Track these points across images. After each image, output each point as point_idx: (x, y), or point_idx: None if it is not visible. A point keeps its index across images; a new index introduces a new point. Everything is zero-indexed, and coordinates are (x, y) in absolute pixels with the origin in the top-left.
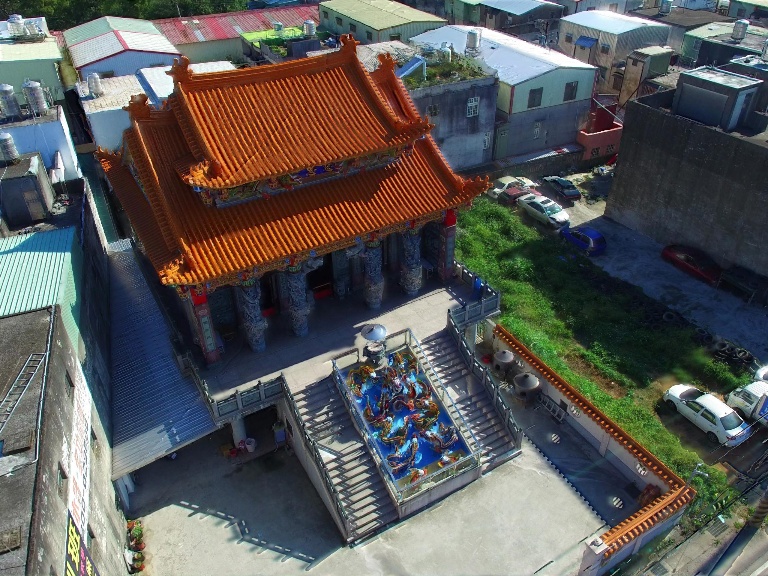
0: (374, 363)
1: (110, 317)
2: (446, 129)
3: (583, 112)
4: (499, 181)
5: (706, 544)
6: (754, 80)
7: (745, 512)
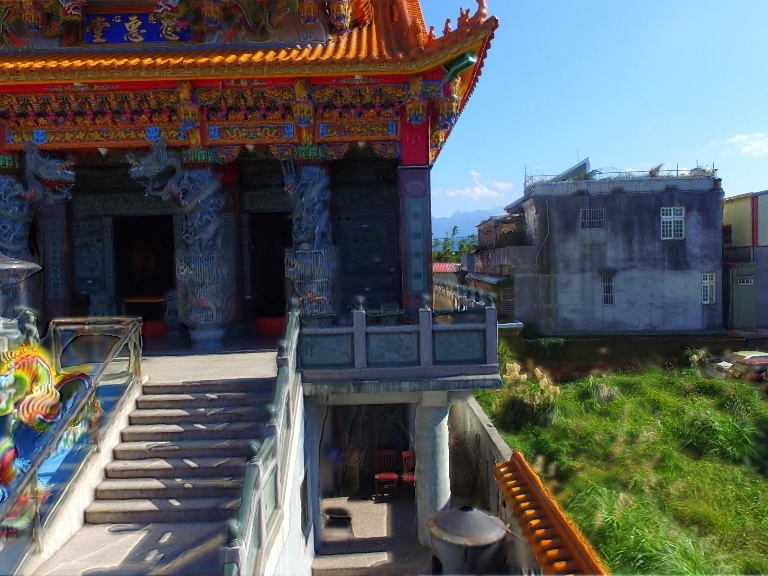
0: None
1: None
2: (620, 254)
3: None
4: (732, 353)
5: None
6: None
7: None
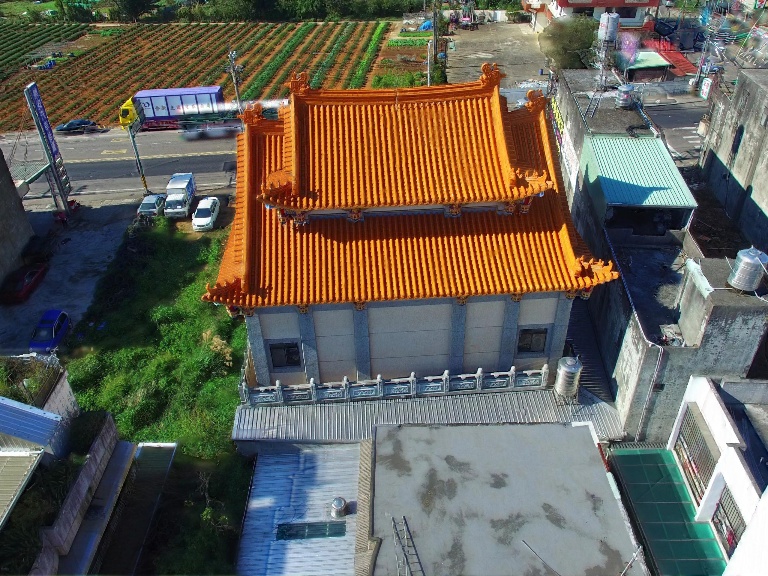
0: None
1: (590, 316)
2: None
3: None
4: None
5: None
6: None
7: None
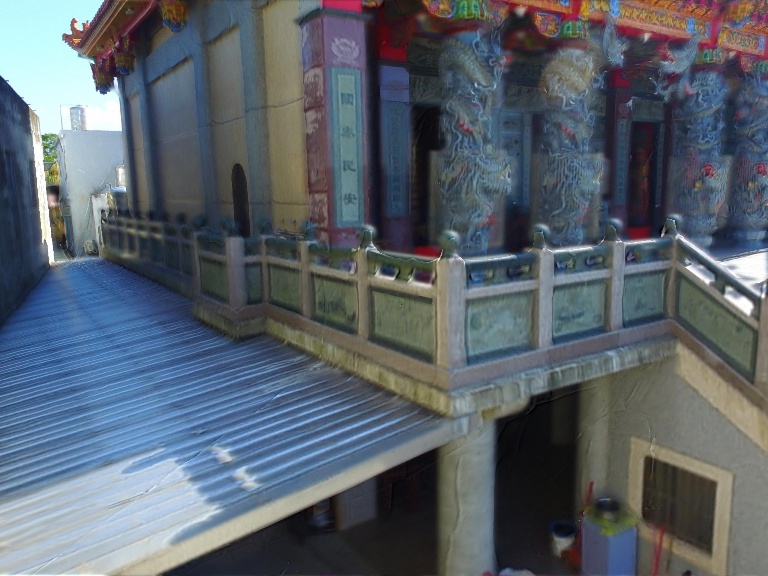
0: None
1: (21, 303)
2: None
3: None
4: None
5: None
6: None
7: None
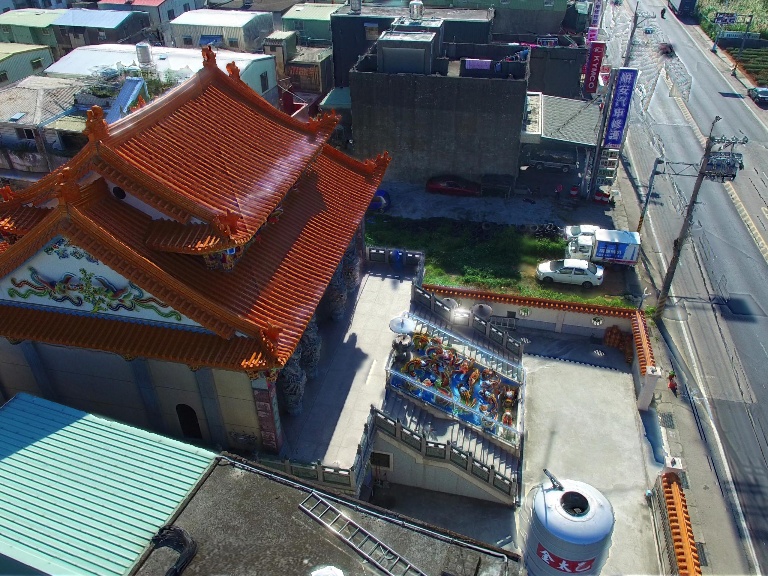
0: (406, 356)
1: None
2: None
3: (275, 100)
4: None
5: (655, 344)
6: (429, 34)
7: (646, 315)
